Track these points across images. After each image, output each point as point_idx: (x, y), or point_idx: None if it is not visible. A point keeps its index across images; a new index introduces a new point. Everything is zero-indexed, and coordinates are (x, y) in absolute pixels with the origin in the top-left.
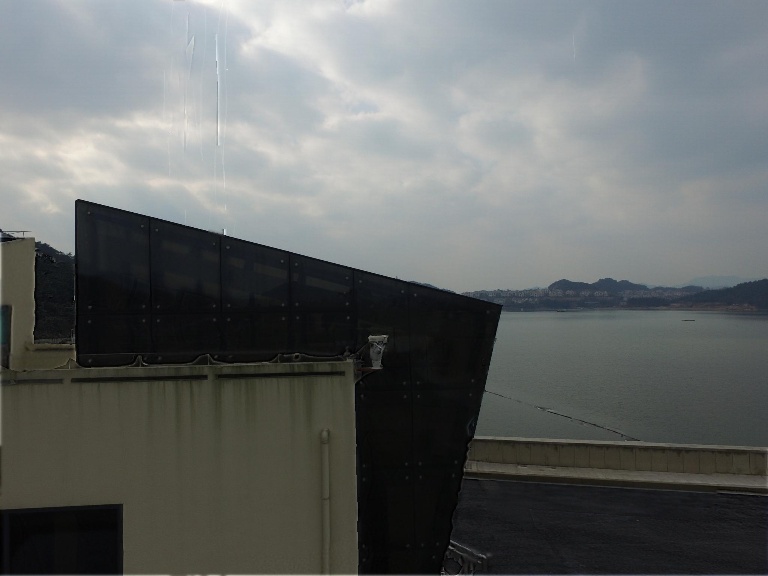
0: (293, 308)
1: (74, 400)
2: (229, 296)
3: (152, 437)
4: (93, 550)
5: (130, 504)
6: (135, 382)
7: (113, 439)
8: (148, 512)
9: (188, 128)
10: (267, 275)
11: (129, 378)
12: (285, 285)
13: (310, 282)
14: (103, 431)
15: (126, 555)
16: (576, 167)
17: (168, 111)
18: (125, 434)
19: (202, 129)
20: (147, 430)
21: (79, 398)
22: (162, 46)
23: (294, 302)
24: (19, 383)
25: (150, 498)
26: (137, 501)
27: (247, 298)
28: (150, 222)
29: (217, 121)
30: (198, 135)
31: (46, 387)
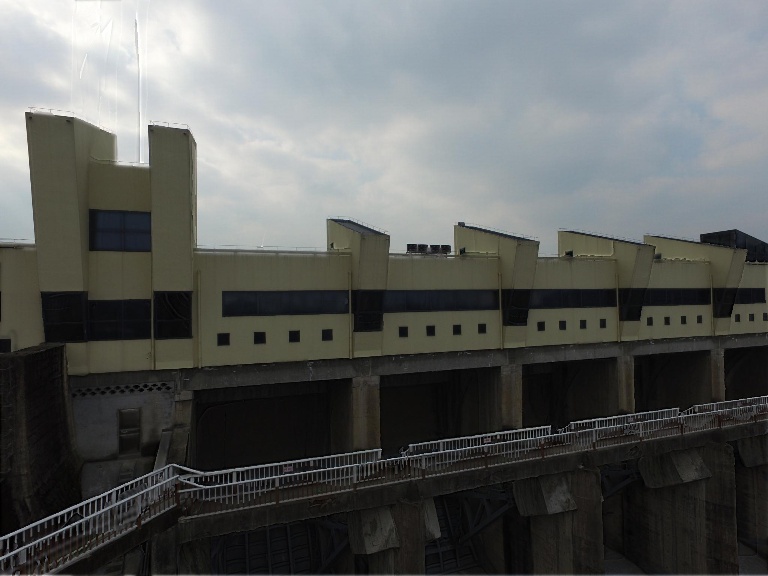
0: (765, 254)
1: (758, 268)
2: (756, 251)
3: (767, 276)
4: (759, 297)
5: (765, 288)
6: (765, 265)
7: (763, 276)
8: (767, 290)
9: (98, 115)
10: (760, 247)
11: (764, 264)
12: (762, 249)
13: (765, 249)
14: (761, 274)
15: (765, 297)
16: (484, 187)
17: (77, 95)
18: (764, 275)
19: (117, 118)
20: (767, 274)
21: (759, 268)
22: (70, 24)
23: (765, 253)
24: (752, 264)
25: (767, 287)
26: (766, 288)
27: (758, 252)
28: (745, 234)
29: (138, 112)
30: (112, 124)
31: (755, 265)
